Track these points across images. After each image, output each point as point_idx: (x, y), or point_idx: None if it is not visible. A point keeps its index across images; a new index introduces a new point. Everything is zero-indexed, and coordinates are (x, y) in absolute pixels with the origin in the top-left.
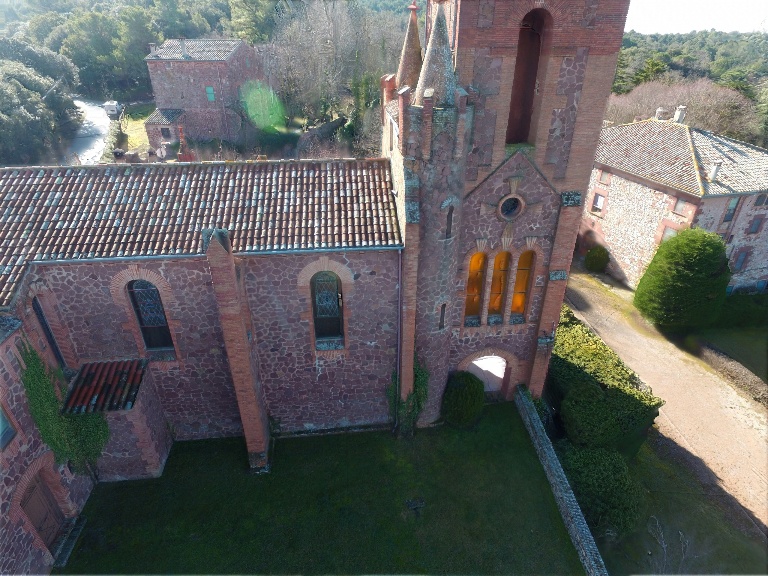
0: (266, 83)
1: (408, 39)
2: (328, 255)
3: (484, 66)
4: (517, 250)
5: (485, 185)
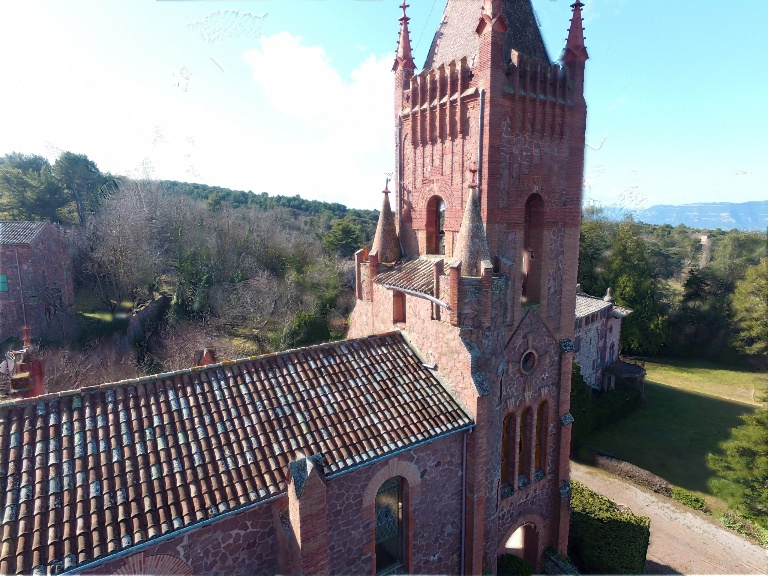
0: (71, 266)
1: (385, 218)
2: (397, 455)
3: (504, 239)
4: (535, 402)
5: (510, 344)
